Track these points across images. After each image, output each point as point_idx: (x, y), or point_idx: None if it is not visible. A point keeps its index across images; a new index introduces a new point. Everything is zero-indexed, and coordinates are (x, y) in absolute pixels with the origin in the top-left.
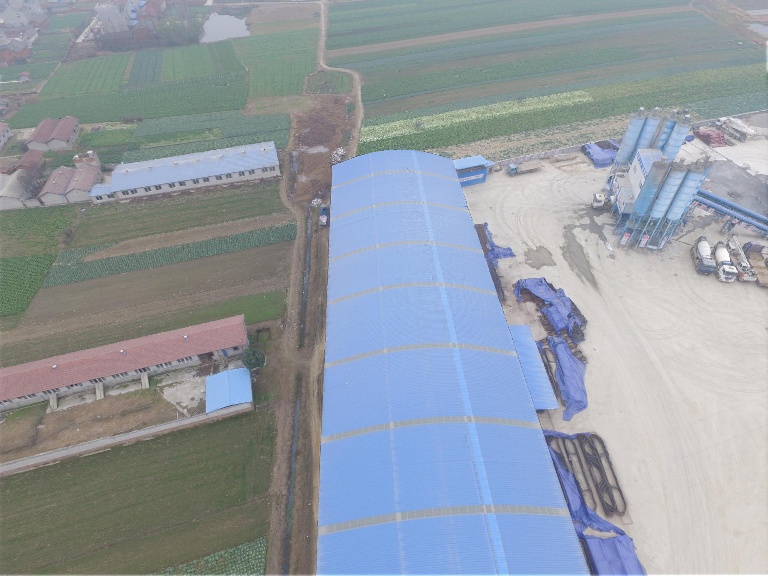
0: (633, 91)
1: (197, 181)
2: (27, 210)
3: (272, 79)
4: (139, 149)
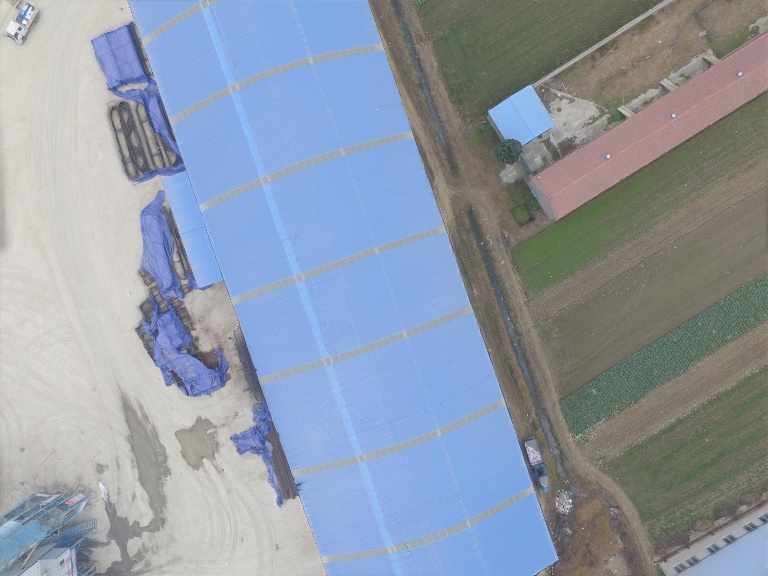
0: None
1: None
2: None
3: None
4: None
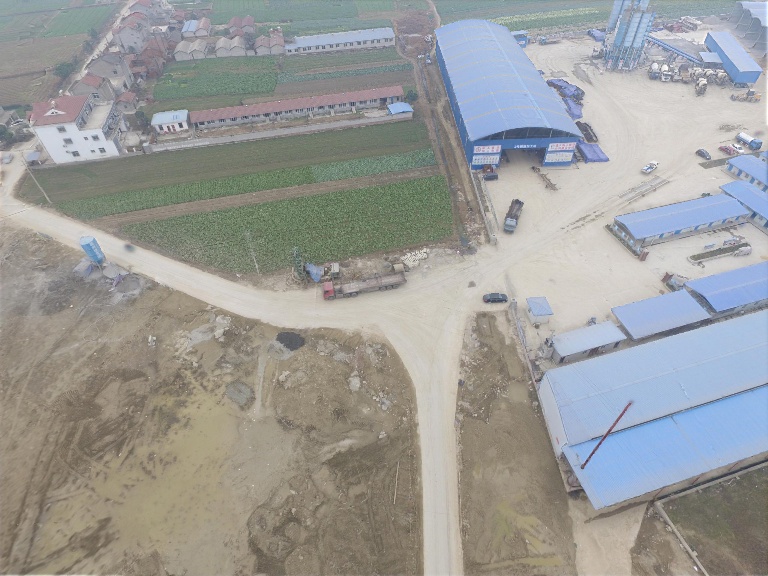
0: None
1: (346, 45)
2: (248, 56)
3: (371, 3)
4: (299, 34)
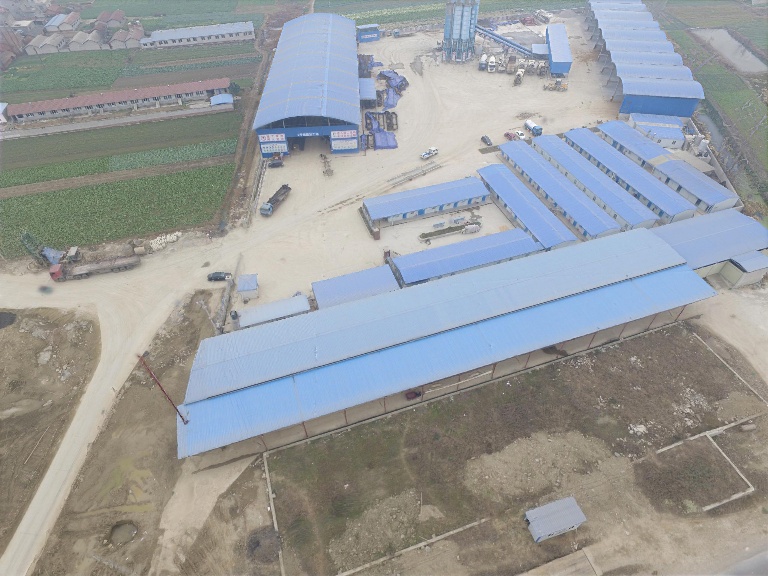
0: (495, 1)
1: (204, 38)
2: (102, 50)
3: None
4: (166, 28)
